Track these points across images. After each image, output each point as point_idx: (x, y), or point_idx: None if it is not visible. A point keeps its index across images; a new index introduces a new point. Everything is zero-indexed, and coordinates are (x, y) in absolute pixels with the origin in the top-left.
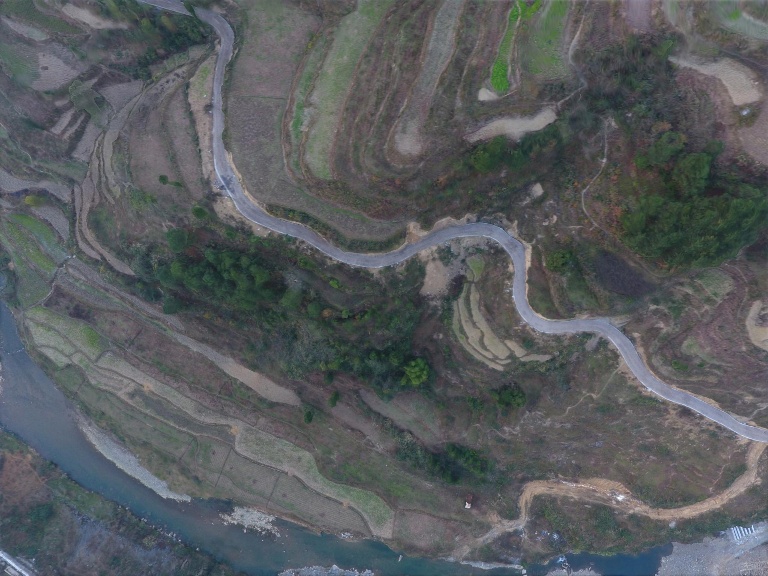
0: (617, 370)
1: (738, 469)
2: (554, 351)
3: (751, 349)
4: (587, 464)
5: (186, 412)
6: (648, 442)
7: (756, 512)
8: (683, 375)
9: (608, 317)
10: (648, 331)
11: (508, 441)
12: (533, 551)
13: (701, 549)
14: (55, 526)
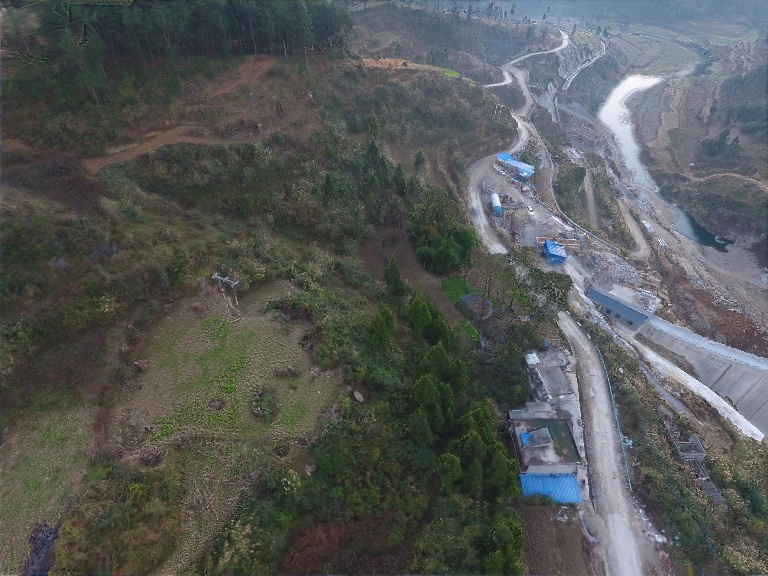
0: None
1: None
2: None
3: None
4: None
5: (671, 103)
6: None
7: None
8: None
9: None
10: None
11: None
12: (679, 186)
13: (738, 264)
14: (600, 78)
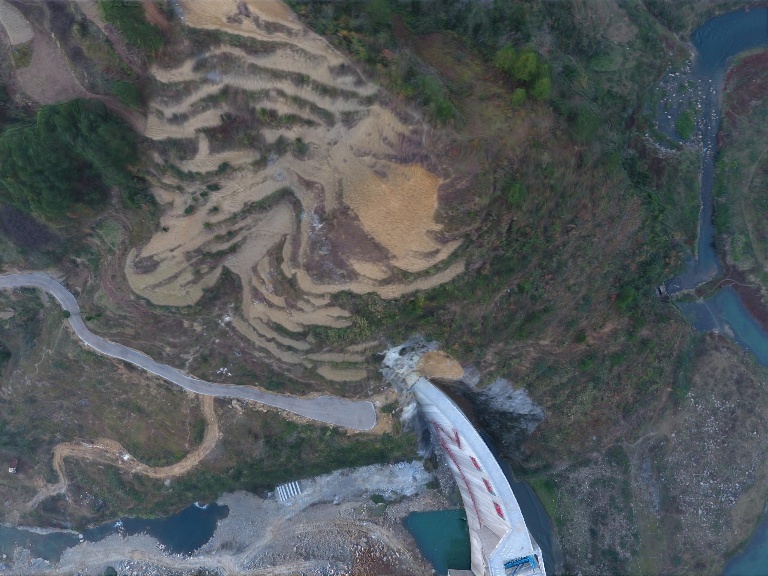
0: (63, 325)
1: (197, 424)
2: (4, 307)
3: (135, 297)
4: (86, 423)
5: None
6: (122, 399)
7: (232, 468)
8: (106, 327)
9: (41, 271)
10: (84, 285)
11: (8, 401)
12: (78, 515)
13: (254, 511)
14: None
